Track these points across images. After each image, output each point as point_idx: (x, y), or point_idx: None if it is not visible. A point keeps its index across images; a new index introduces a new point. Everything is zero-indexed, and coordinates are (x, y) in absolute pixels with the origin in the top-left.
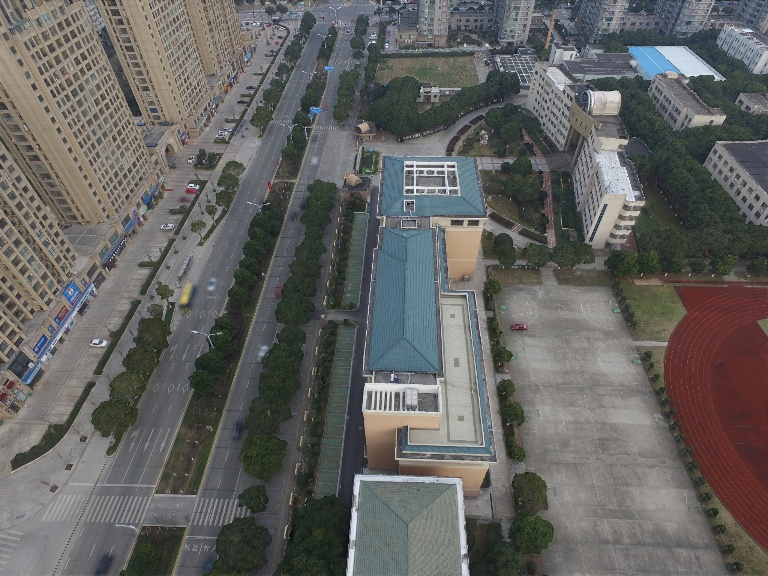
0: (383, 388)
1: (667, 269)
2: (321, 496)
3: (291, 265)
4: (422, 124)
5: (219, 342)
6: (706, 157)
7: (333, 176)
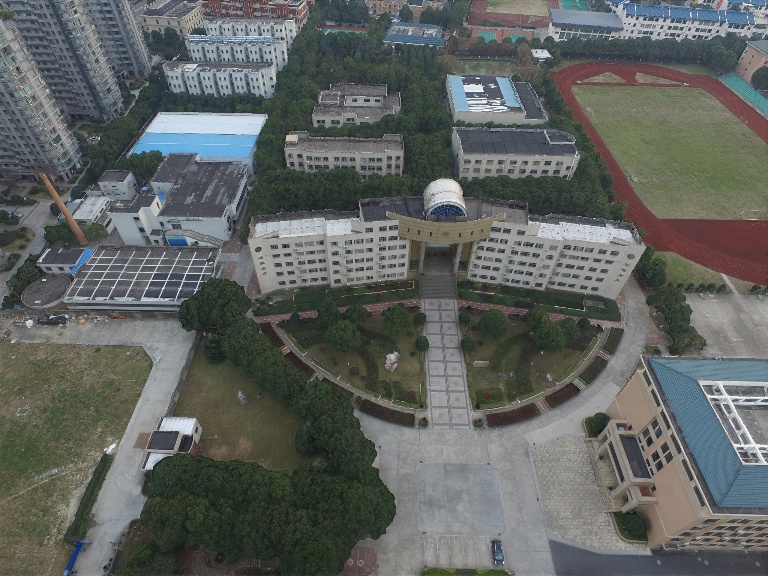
0: None
1: None
2: None
3: None
4: (375, 457)
5: None
6: (453, 171)
7: None
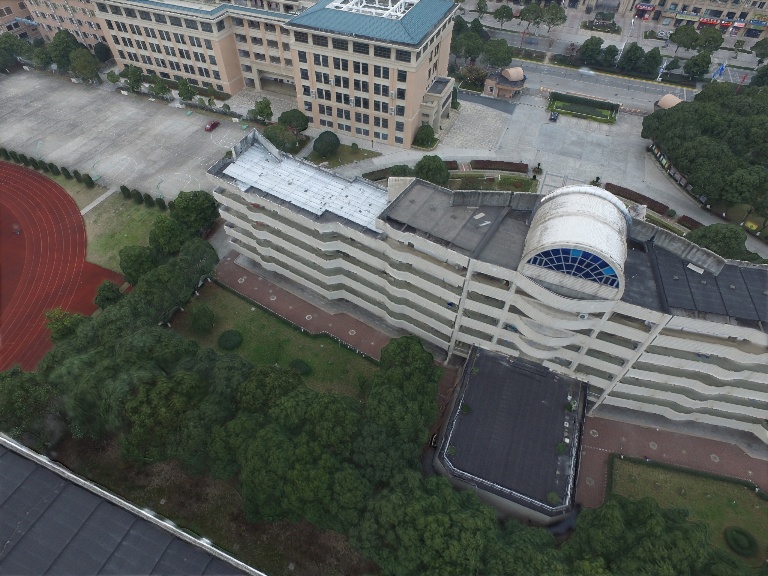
0: None
1: None
2: None
3: None
4: None
5: None
6: None
7: (552, 85)
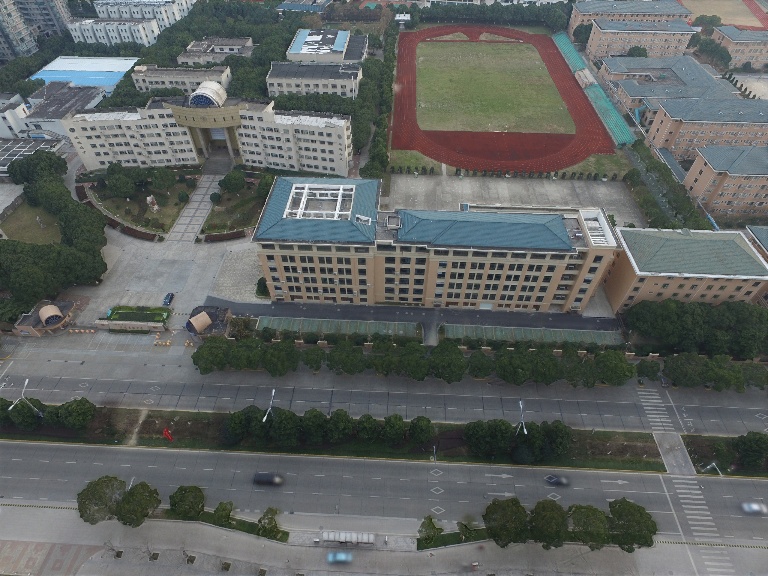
0: None
1: None
2: (614, 341)
3: (382, 368)
4: (101, 243)
5: (511, 425)
6: (264, 94)
7: (153, 360)
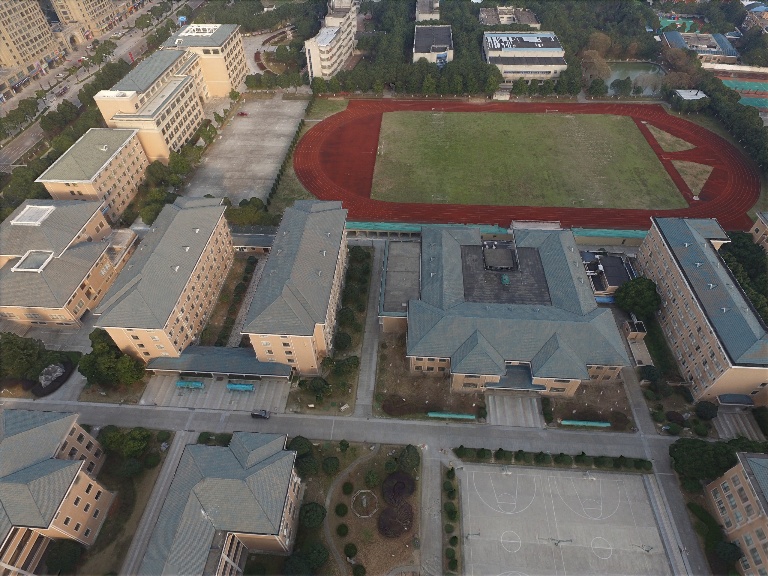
0: (111, 94)
1: (345, 89)
2: None
3: None
4: (247, 24)
5: (61, 109)
6: None
7: None
